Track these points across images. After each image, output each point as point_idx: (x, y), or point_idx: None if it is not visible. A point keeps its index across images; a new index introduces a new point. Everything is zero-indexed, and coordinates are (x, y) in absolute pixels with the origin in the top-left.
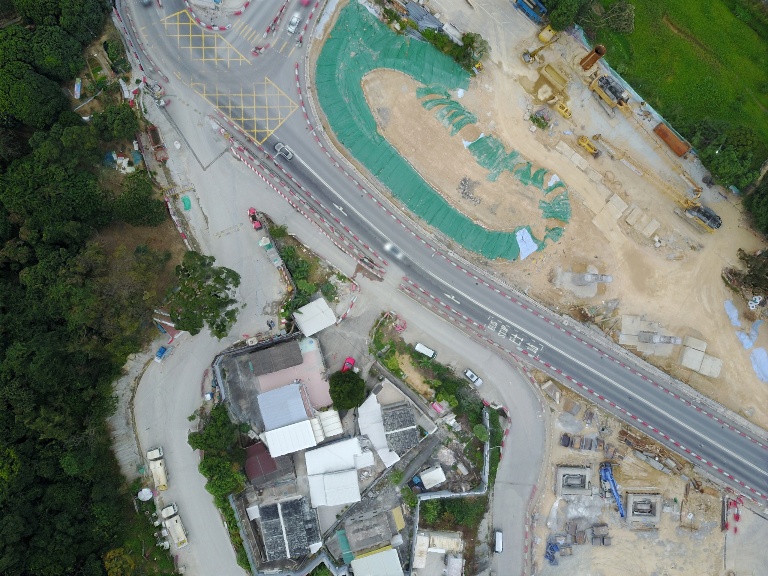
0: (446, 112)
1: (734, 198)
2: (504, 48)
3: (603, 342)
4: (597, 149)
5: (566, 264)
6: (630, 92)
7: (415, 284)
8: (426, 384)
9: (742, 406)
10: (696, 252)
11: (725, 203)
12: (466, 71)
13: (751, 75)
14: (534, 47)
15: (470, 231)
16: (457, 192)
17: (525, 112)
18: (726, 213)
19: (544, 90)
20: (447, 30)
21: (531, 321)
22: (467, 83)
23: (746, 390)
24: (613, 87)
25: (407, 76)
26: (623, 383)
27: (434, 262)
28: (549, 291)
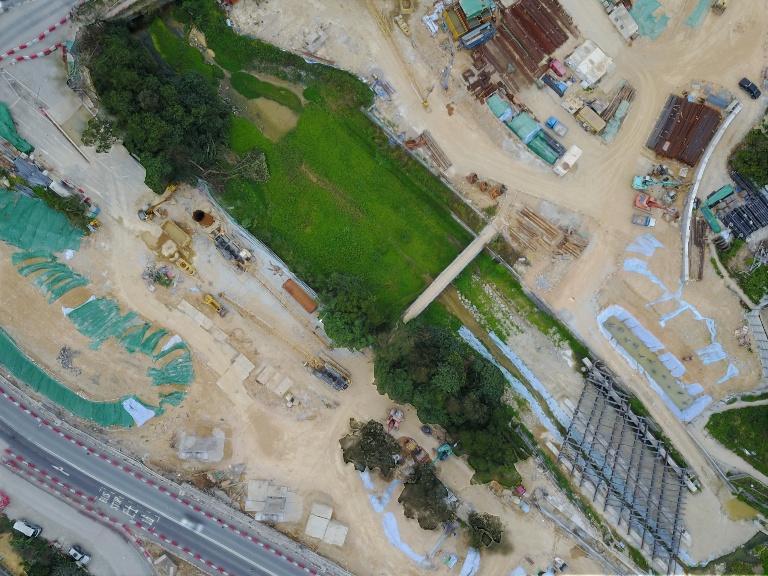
0: (46, 278)
1: (371, 354)
2: (125, 203)
3: (224, 511)
4: (221, 308)
5: (190, 428)
6: (259, 247)
7: (17, 457)
8: (23, 566)
9: (374, 572)
10: (332, 410)
11: (363, 358)
12: (80, 229)
13: (393, 224)
14: (154, 202)
15: (76, 401)
16: (57, 362)
17: (144, 270)
18: (363, 369)
19: (168, 246)
20: (54, 189)
21: (146, 491)
22: (78, 243)
23: (378, 556)
24: (230, 246)
25: (1, 242)
26: (245, 553)
27: (41, 432)
28: (171, 457)
